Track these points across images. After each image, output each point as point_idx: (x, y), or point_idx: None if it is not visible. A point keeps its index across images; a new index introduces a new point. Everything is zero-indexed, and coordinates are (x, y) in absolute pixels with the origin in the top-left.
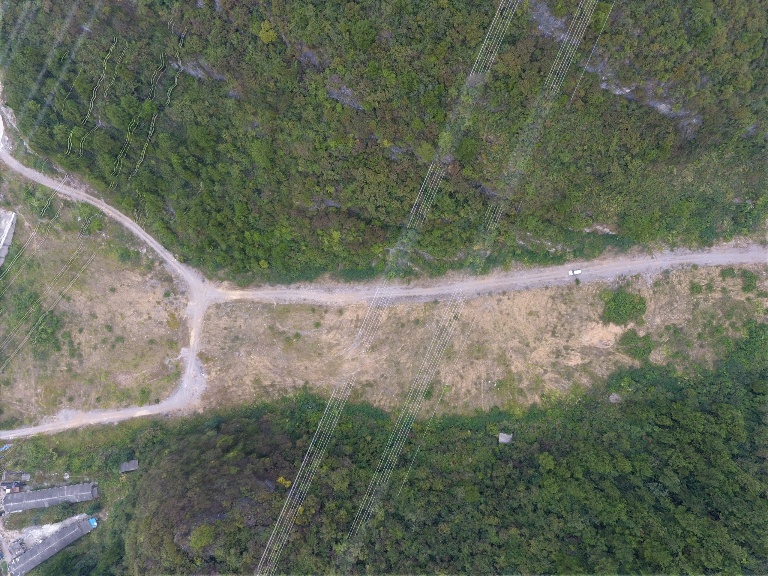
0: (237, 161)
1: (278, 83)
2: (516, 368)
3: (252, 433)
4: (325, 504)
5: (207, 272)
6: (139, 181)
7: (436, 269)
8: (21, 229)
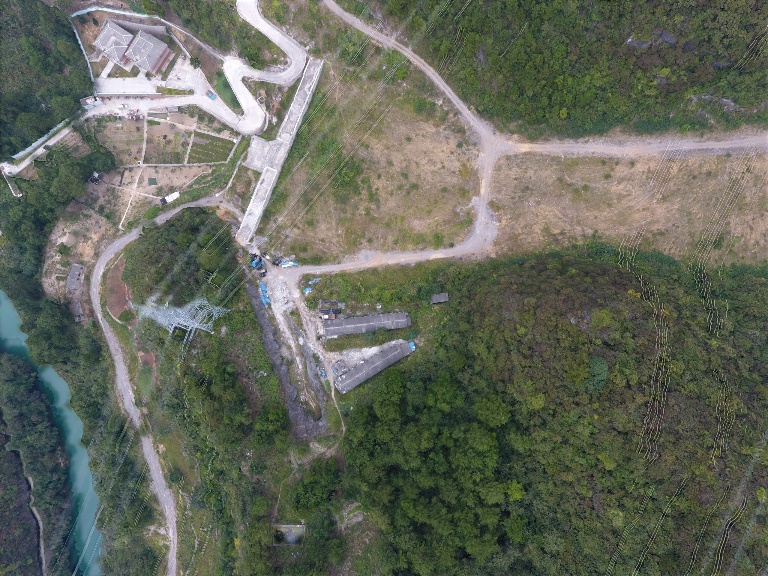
0: None
1: None
2: None
3: (569, 264)
4: (681, 312)
5: (500, 124)
6: (467, 20)
7: (734, 121)
8: (325, 78)
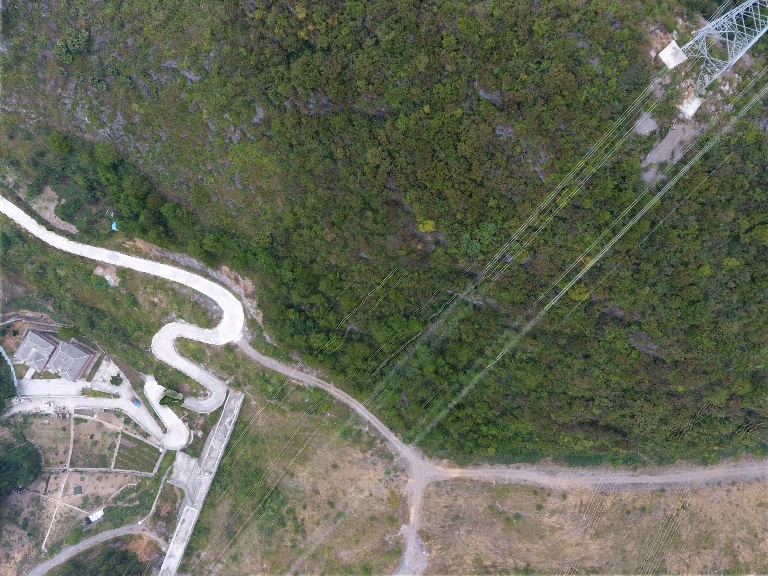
0: (492, 371)
1: (575, 330)
2: (743, 558)
3: None
4: None
5: (428, 451)
6: (385, 381)
7: (667, 460)
8: (247, 407)
